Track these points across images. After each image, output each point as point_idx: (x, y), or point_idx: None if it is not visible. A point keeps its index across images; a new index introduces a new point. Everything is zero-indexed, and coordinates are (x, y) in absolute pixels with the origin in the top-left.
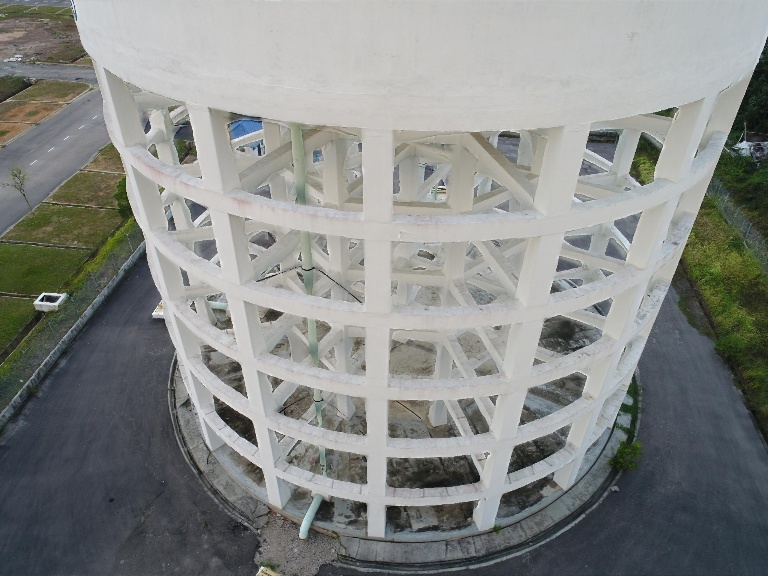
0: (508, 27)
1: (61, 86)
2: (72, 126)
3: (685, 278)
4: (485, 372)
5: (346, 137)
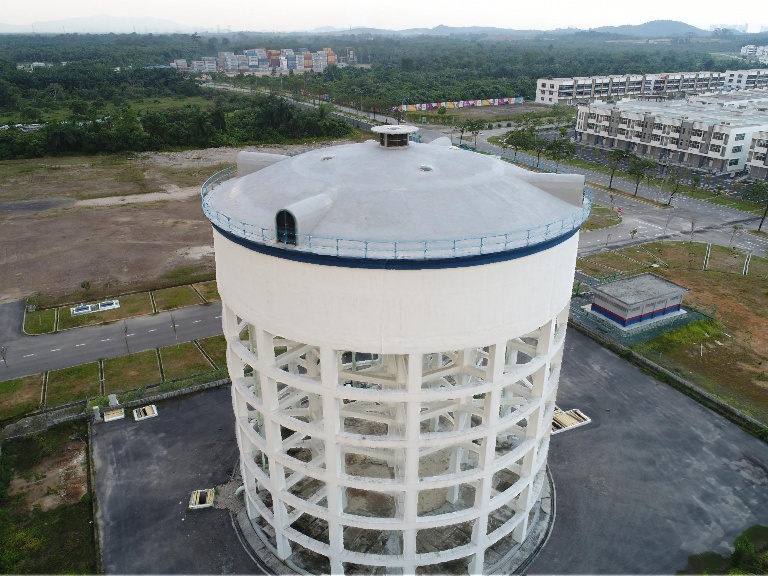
0: (236, 282)
1: None
2: None
3: None
4: None
5: None
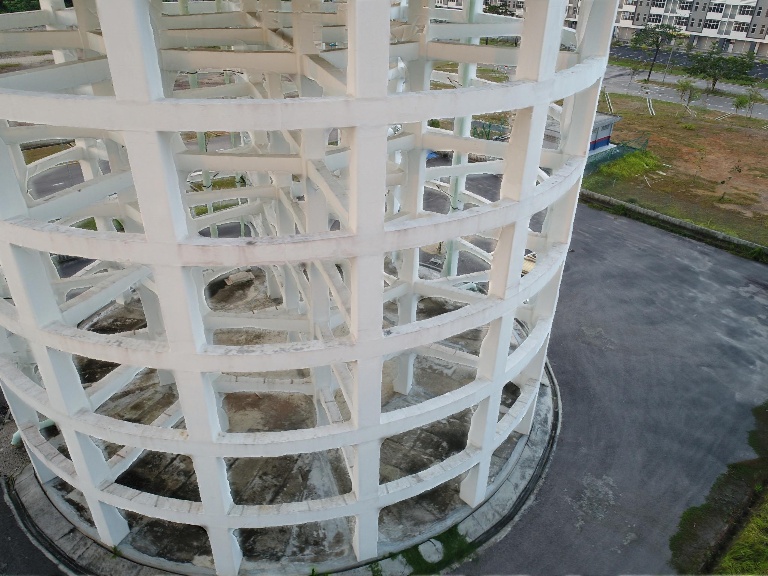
0: None
1: None
2: None
3: (751, 488)
4: None
5: (93, 49)
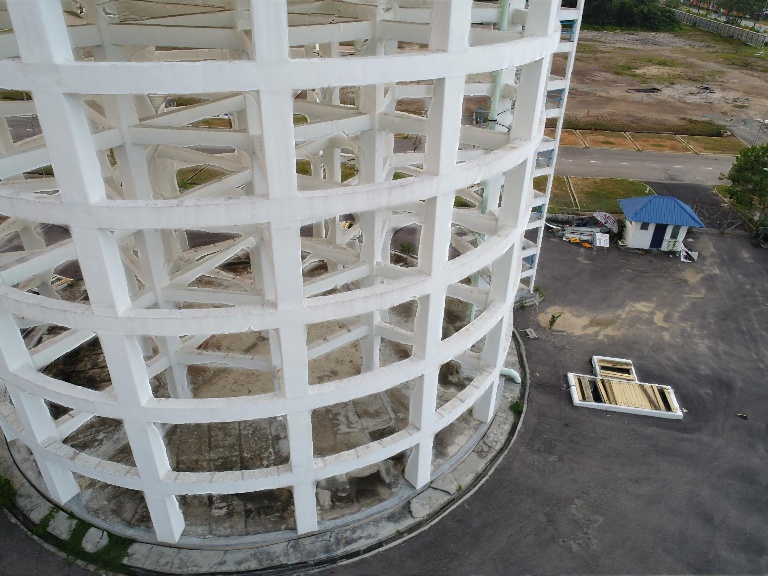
0: None
1: (732, 145)
2: (649, 161)
3: None
4: (196, 391)
5: None
